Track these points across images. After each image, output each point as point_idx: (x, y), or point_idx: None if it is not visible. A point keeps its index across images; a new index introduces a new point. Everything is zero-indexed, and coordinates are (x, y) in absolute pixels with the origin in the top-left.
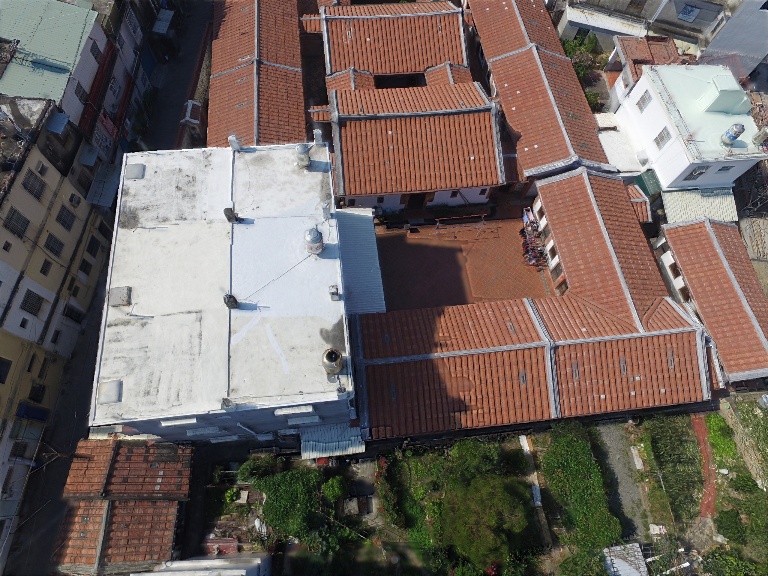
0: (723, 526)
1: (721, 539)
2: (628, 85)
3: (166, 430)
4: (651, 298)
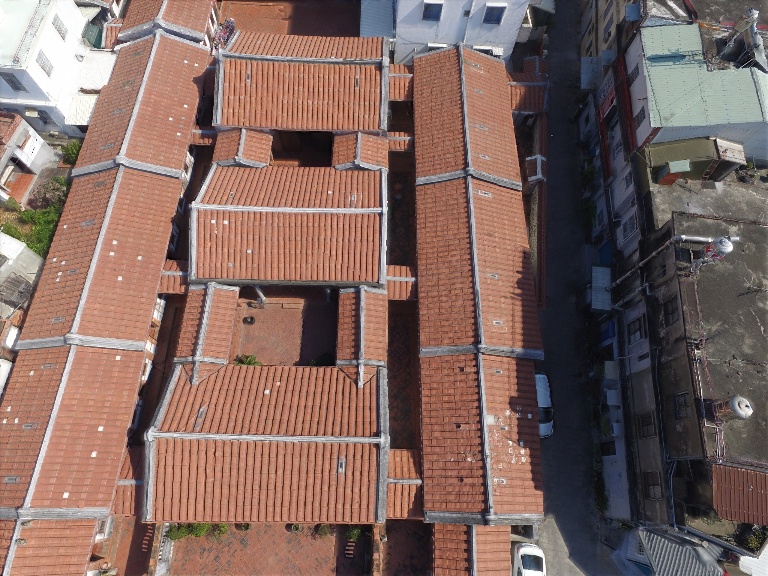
0: None
1: None
2: None
3: None
4: None
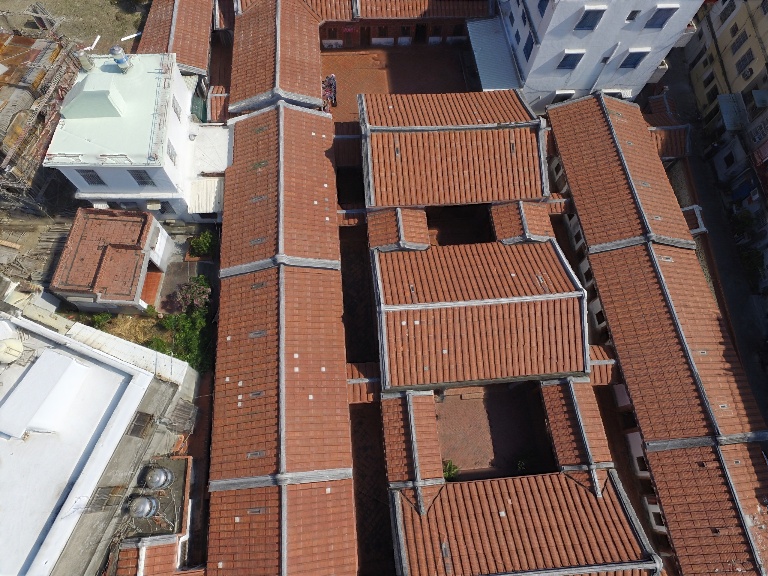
0: None
1: None
2: (157, 227)
3: None
4: (256, 8)
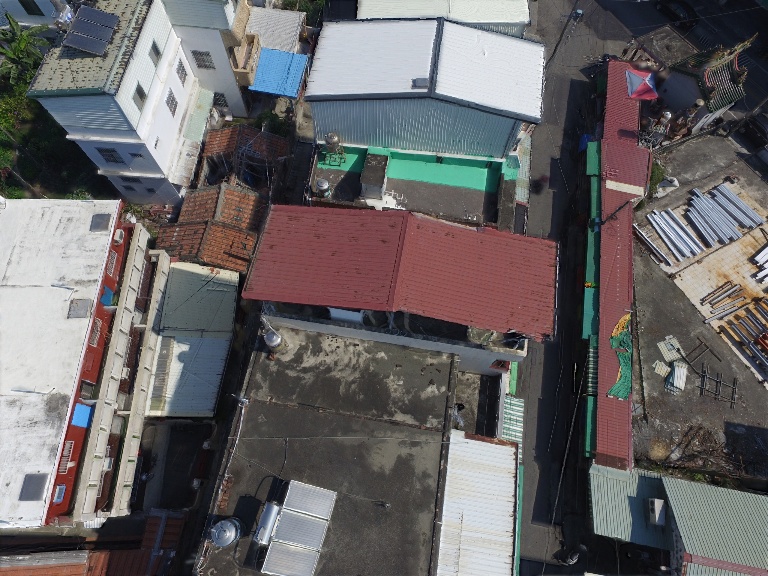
0: None
1: None
2: None
3: None
4: None
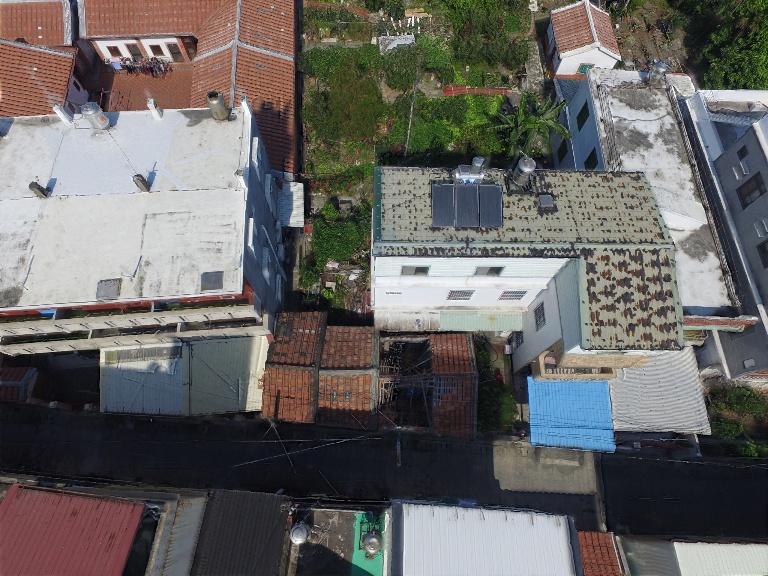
0: (373, 5)
1: (381, 13)
2: None
3: (259, 285)
4: None
